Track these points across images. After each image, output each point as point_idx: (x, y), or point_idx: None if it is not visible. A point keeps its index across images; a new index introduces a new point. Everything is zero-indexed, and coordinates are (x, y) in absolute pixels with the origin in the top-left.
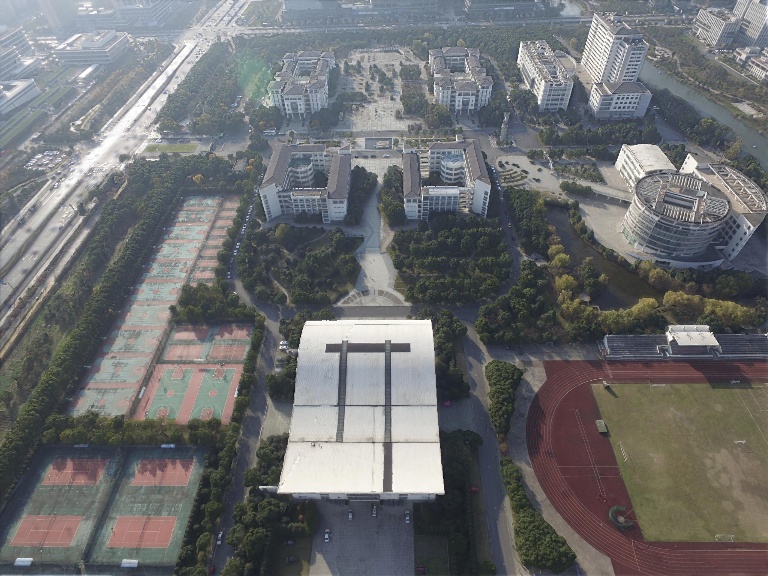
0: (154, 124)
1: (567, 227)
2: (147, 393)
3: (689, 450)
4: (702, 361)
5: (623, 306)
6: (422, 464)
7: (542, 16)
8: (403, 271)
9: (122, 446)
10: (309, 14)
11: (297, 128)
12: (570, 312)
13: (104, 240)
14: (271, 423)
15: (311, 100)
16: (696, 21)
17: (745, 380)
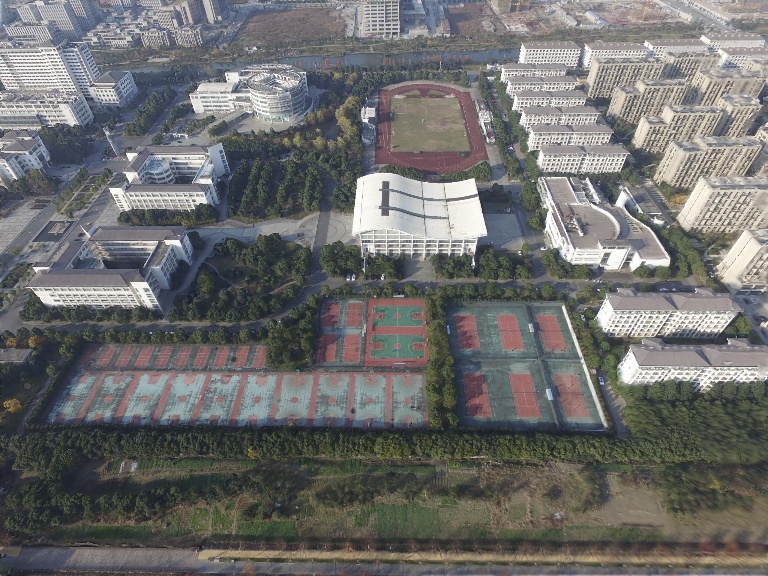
0: None
1: None
2: None
3: (427, 133)
4: (378, 120)
5: (336, 134)
6: (458, 188)
7: None
8: None
9: None
10: None
11: None
12: (345, 144)
13: None
14: (422, 277)
15: None
16: None
17: (389, 113)
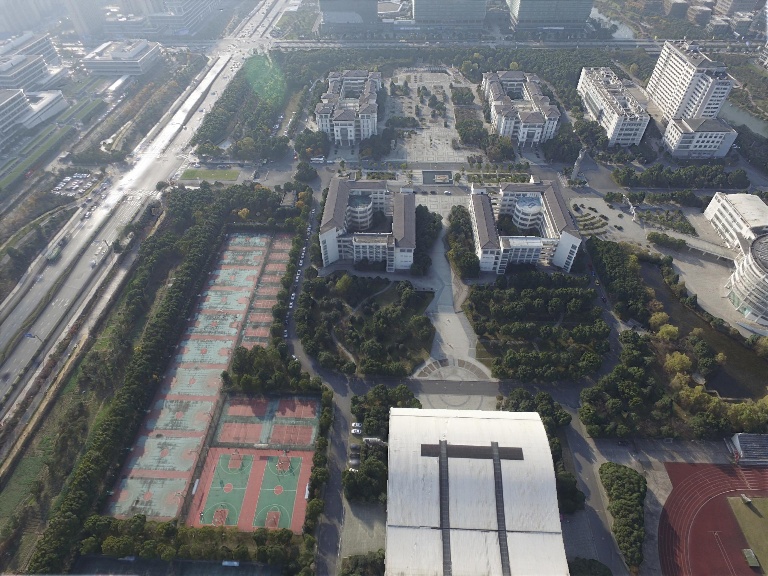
0: (191, 146)
1: (662, 287)
2: (201, 486)
3: None
4: None
5: (745, 392)
6: None
7: (594, 38)
8: (484, 336)
9: (175, 560)
10: (348, 28)
11: (346, 156)
12: (691, 402)
13: (143, 285)
14: (350, 535)
15: (362, 126)
16: (764, 50)
17: None
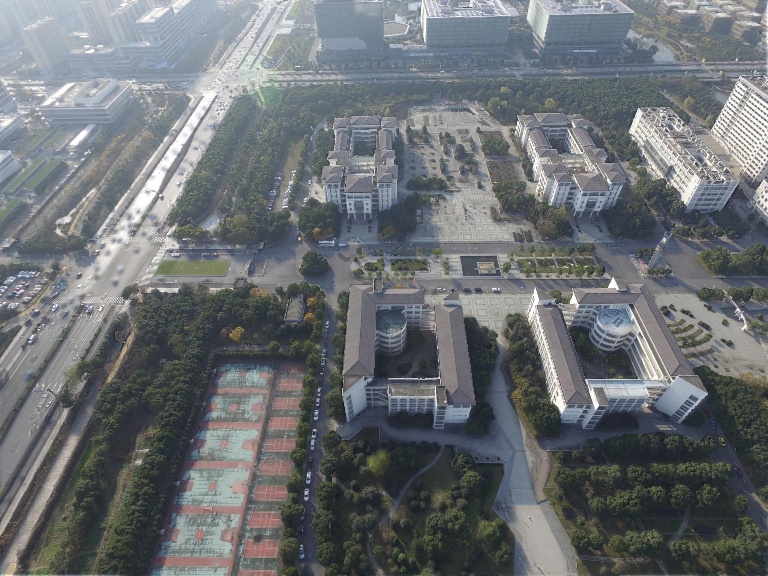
0: (169, 226)
1: None
2: None
3: None
4: None
5: None
6: None
7: (633, 62)
8: (585, 550)
9: None
10: (350, 55)
11: (362, 235)
12: None
13: (99, 468)
14: None
15: (380, 195)
16: None
17: None
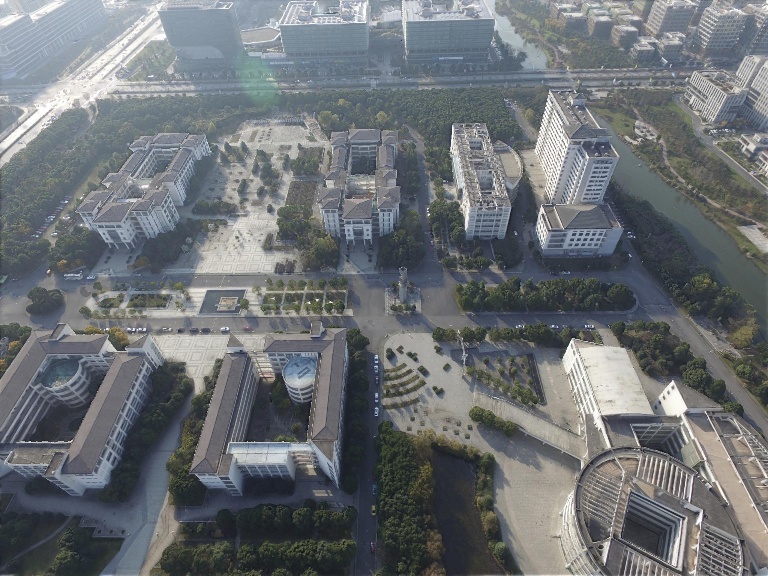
0: None
1: (469, 514)
2: None
3: None
4: None
5: None
6: None
7: (497, 70)
8: None
9: None
10: (208, 64)
11: (118, 266)
12: None
13: None
14: None
15: (142, 223)
16: (689, 85)
17: None
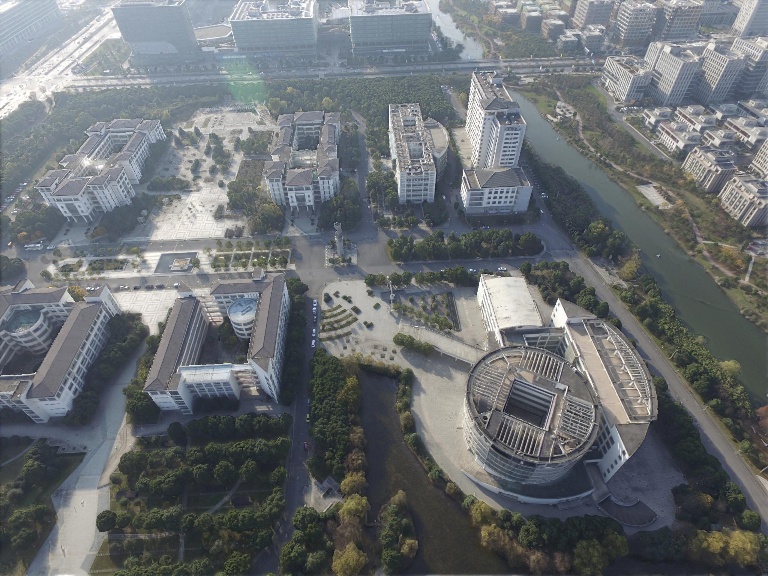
0: None
1: (390, 417)
2: None
3: None
4: None
5: None
6: None
7: (436, 60)
8: (117, 529)
9: None
10: (162, 59)
11: (77, 237)
12: None
13: None
14: None
15: (98, 197)
16: (604, 70)
17: None
